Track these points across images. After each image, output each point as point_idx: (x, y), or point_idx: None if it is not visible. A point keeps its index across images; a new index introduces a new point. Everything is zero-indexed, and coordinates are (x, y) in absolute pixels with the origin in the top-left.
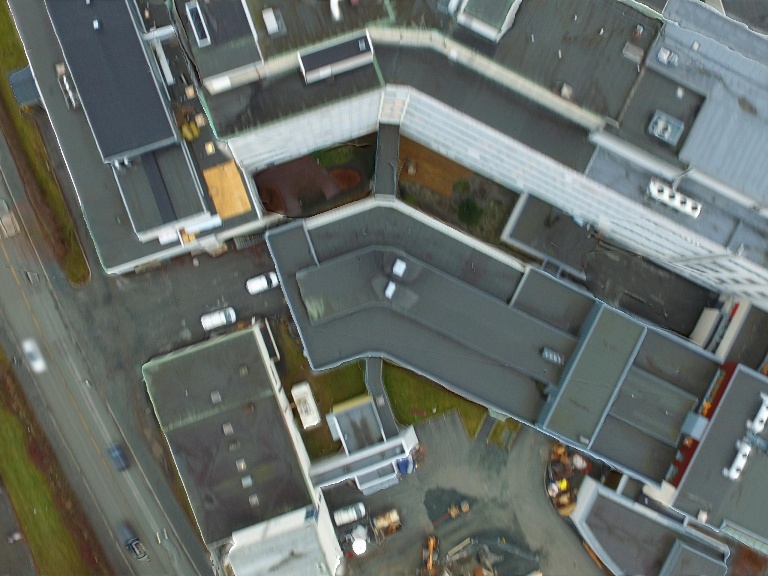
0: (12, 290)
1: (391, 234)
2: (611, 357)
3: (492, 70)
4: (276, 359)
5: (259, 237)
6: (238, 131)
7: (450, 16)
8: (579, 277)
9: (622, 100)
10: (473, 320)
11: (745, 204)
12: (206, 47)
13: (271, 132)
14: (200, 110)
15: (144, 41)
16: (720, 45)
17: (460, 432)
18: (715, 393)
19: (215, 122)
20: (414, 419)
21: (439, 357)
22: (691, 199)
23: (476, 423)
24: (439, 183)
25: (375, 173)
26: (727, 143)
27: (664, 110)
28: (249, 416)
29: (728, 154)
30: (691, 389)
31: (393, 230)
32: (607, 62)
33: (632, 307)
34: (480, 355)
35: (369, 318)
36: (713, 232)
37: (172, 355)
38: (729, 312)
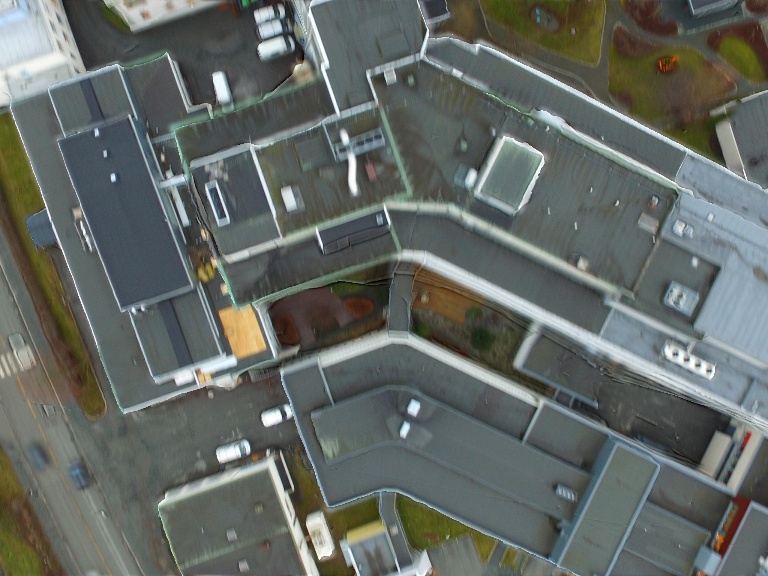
0: (28, 423)
1: (405, 371)
2: (624, 495)
3: (508, 241)
4: (291, 491)
5: (274, 370)
6: (256, 298)
7: (467, 191)
8: (591, 406)
9: (637, 270)
10: (487, 458)
11: (759, 366)
12: (225, 226)
13: (288, 288)
14: None
15: (161, 190)
16: (735, 216)
17: (473, 556)
18: (728, 528)
19: (233, 289)
20: (427, 543)
21: (453, 494)
22: (706, 361)
23: (489, 547)
24: (452, 310)
25: (389, 308)
26: (742, 312)
27: (679, 281)
28: (264, 553)
29: (743, 323)
30: (704, 522)
31: (407, 367)
32: (622, 232)
33: (644, 430)
34: (494, 492)
35: (383, 455)
36: (727, 390)
37: (188, 490)
38: (741, 440)
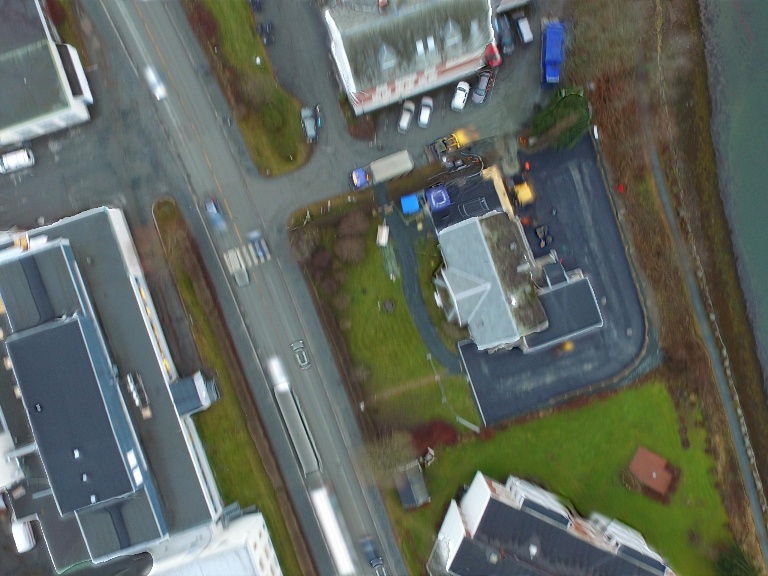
0: (232, 194)
1: None
2: None
3: None
4: None
5: None
6: None
7: None
8: None
9: None
10: None
11: None
12: None
13: None
14: (9, 373)
15: None
16: None
17: None
18: None
19: None
20: None
21: None
22: None
23: None
24: None
25: None
26: None
27: None
28: None
29: None
30: None
31: None
32: None
33: None
34: None
35: None
36: None
37: None
38: None
